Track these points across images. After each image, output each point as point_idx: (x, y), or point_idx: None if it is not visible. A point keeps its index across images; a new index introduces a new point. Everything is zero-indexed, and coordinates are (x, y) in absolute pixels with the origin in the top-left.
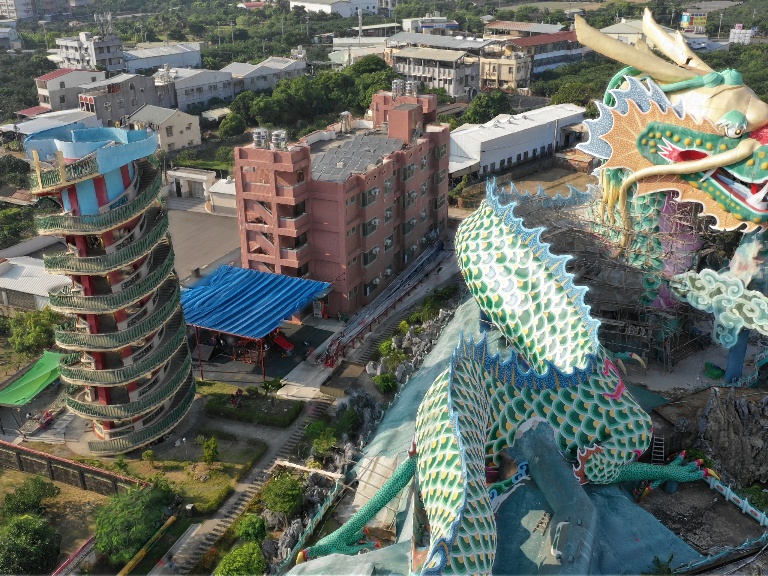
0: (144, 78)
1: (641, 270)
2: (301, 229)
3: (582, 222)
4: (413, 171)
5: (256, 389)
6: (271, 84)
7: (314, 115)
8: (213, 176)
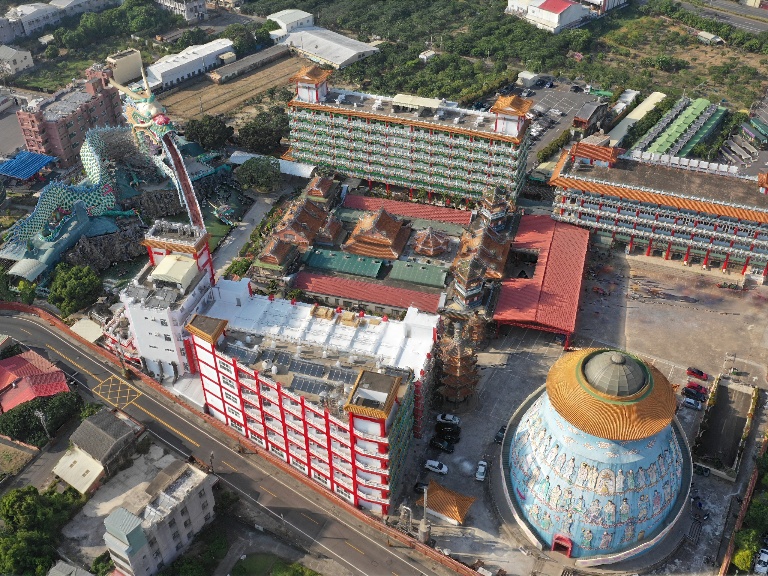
0: (2, 20)
1: (143, 154)
2: (44, 139)
3: (132, 137)
4: (95, 109)
5: (28, 195)
6: (85, 8)
7: (103, 37)
8: (31, 96)
